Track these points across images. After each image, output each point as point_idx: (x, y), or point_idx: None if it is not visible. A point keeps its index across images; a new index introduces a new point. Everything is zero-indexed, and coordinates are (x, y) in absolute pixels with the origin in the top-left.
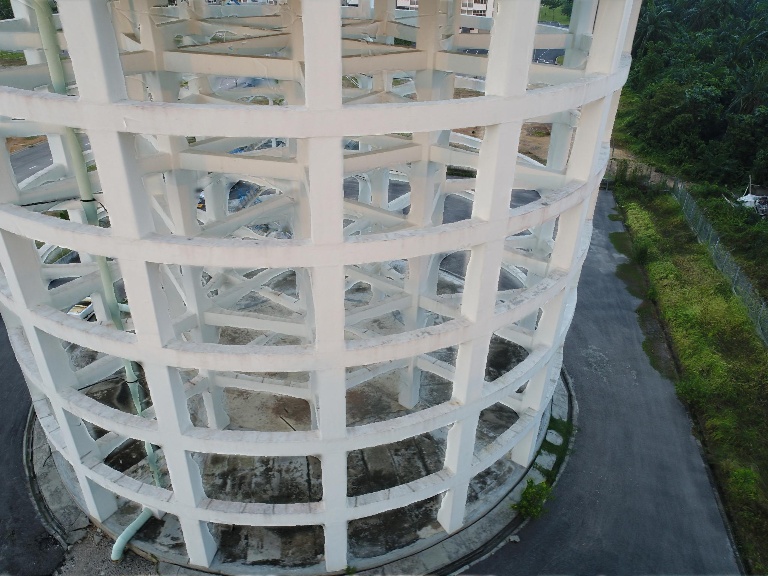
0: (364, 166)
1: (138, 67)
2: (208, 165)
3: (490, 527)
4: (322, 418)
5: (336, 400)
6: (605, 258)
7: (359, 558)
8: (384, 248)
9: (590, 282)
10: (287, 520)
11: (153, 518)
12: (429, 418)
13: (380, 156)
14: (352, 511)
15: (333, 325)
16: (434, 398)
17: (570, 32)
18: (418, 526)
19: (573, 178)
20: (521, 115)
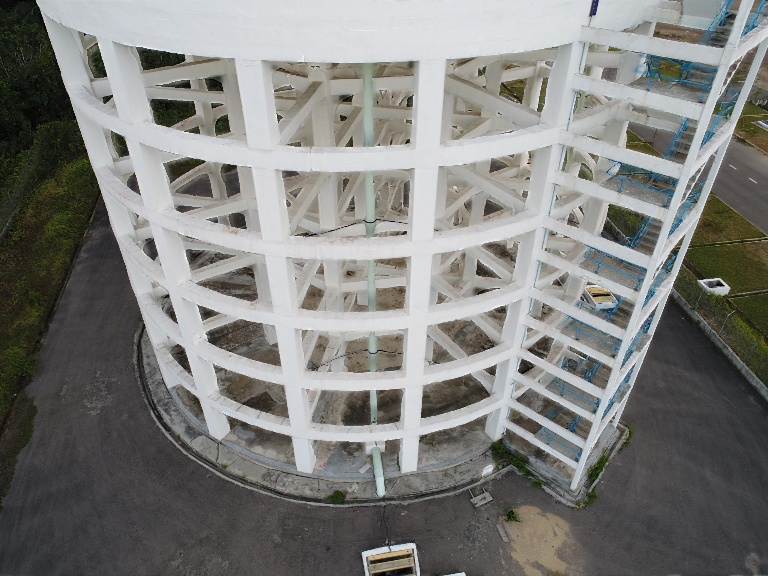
0: None
1: None
2: None
3: (208, 251)
4: None
5: None
6: None
7: None
8: None
9: (42, 568)
10: None
11: None
12: None
13: None
14: None
15: None
16: (253, 298)
17: None
18: None
19: None
20: None
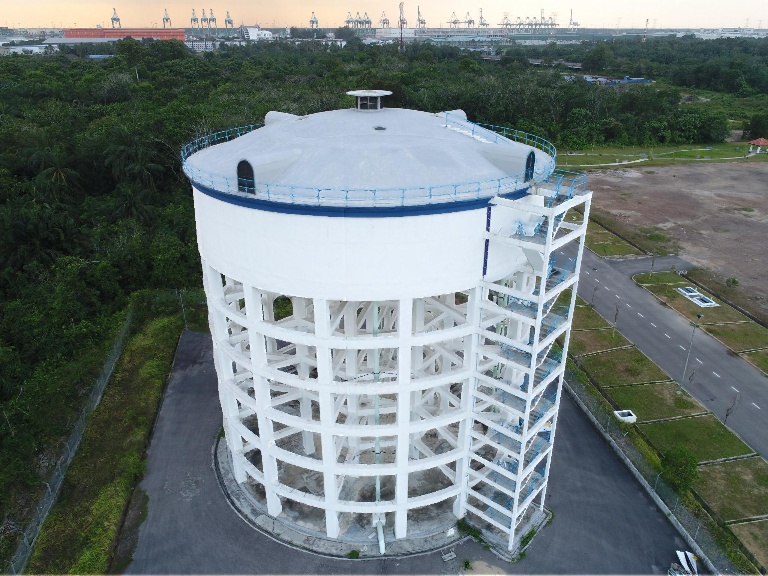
0: None
1: None
2: None
3: None
4: None
5: None
6: None
7: None
8: None
9: None
10: None
11: None
12: None
13: None
14: None
15: None
16: None
17: None
18: None
19: None
20: None
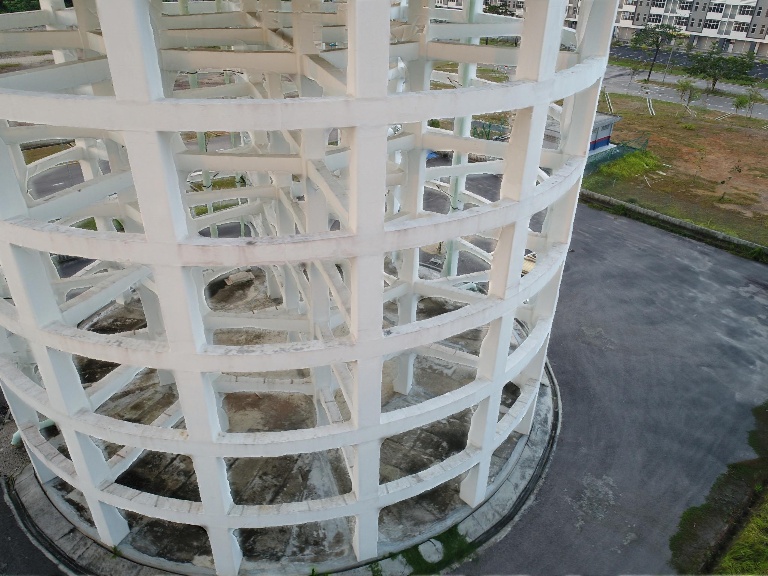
0: (229, 167)
1: (65, 43)
2: (121, 139)
3: None
4: (46, 387)
5: (49, 375)
6: (762, 383)
7: (131, 546)
8: (35, 237)
9: (701, 403)
10: (58, 472)
11: (55, 427)
12: (147, 435)
13: (247, 160)
14: (99, 493)
15: (22, 299)
16: None
17: (577, 52)
18: (202, 551)
19: (350, 226)
20: (152, 125)
